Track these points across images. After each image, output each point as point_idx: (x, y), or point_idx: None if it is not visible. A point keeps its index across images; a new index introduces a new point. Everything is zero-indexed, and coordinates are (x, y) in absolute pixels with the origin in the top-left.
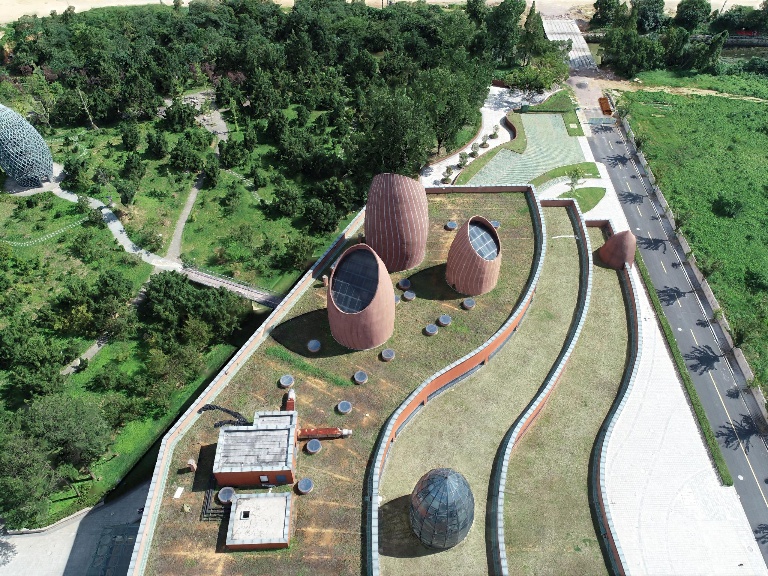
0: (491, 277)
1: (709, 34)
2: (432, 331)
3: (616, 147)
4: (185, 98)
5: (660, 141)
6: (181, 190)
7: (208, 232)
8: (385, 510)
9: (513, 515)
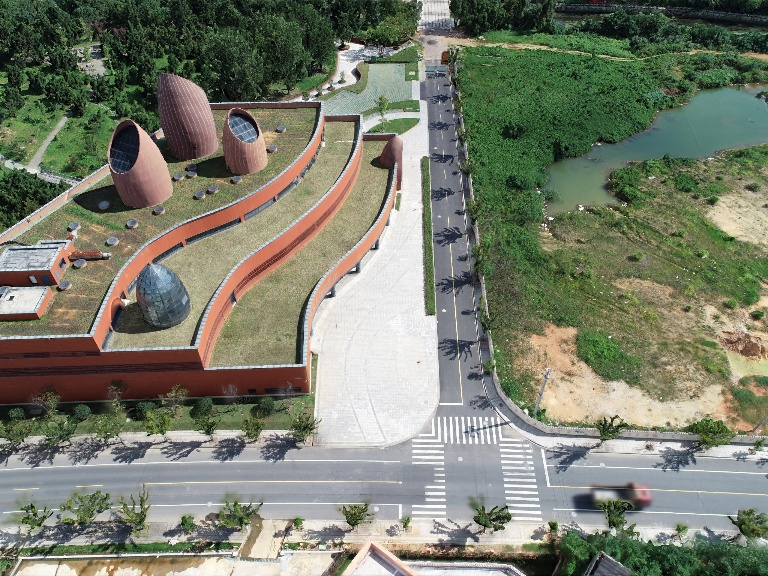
0: (254, 158)
1: (564, 2)
2: (199, 196)
3: (442, 89)
4: (75, 50)
5: (481, 84)
6: (52, 117)
7: (68, 148)
8: (129, 307)
9: (239, 321)
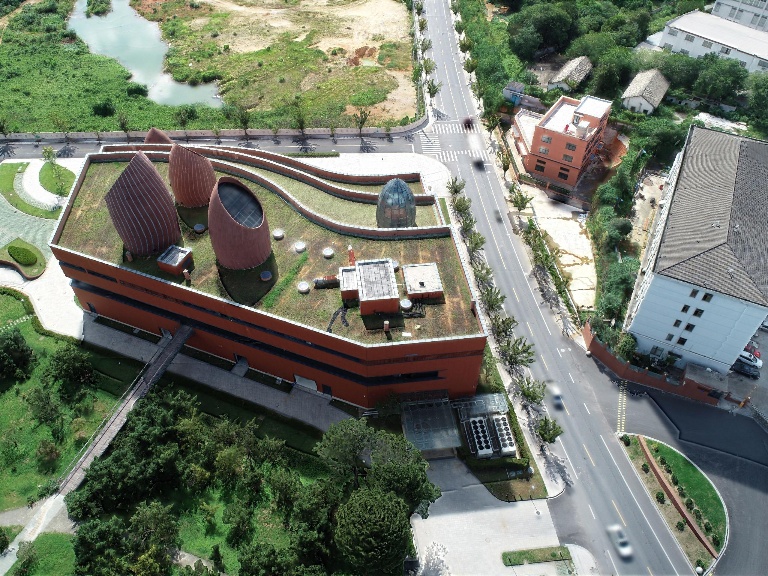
0: None
1: None
2: None
3: None
4: None
5: None
6: None
7: None
8: None
9: None
